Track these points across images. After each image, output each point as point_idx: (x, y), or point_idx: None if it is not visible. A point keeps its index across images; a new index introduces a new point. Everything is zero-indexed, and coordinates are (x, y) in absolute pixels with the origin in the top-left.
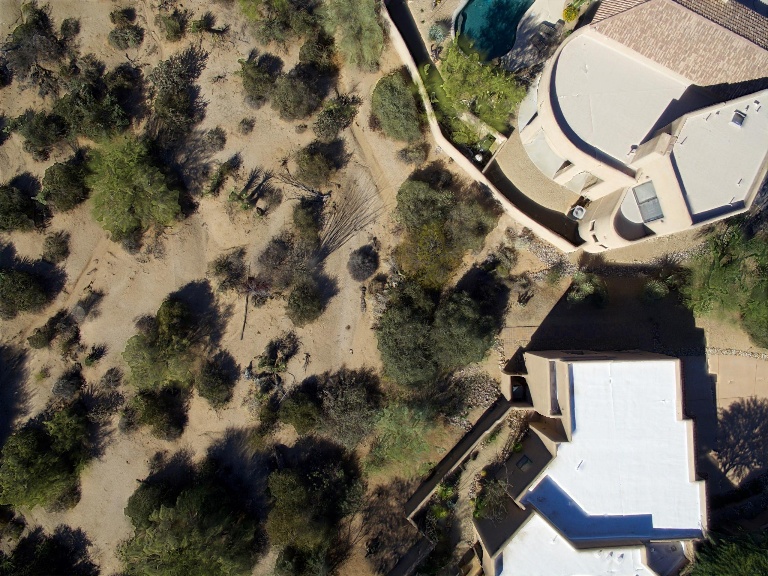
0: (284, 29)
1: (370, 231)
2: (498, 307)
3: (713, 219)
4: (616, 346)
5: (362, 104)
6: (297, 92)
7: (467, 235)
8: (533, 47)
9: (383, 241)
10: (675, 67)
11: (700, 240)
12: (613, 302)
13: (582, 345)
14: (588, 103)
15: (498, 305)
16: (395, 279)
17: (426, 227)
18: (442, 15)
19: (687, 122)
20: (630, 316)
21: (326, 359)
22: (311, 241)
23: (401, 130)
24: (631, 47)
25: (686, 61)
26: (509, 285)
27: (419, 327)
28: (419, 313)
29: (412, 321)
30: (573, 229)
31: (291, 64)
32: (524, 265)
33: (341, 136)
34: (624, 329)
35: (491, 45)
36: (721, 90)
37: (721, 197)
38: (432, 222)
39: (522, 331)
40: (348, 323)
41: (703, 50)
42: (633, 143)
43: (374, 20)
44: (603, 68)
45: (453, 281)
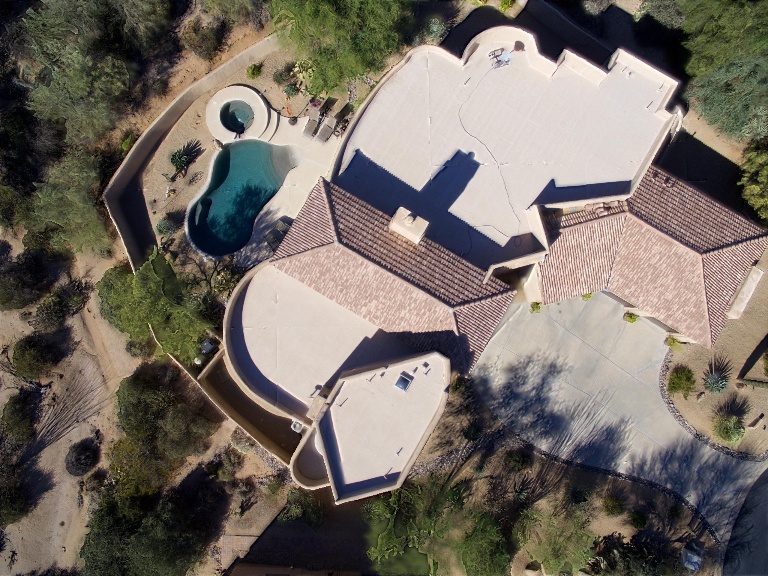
0: (13, 212)
1: (93, 423)
2: (219, 512)
3: (359, 496)
4: (336, 565)
5: (94, 290)
6: (6, 288)
7: (170, 449)
8: (268, 244)
9: (107, 434)
10: (357, 311)
11: (437, 454)
12: (335, 518)
13: (301, 561)
14: (275, 336)
15: (219, 510)
16: (114, 476)
17: (136, 432)
18: (176, 205)
19: (348, 382)
20: (353, 533)
21: (35, 557)
22: (23, 436)
23: (118, 328)
24: (312, 287)
25: (367, 306)
26: (229, 492)
27: (115, 541)
28: (122, 523)
29: (111, 533)
30: (301, 436)
31: (19, 248)
32: (250, 469)
33: (69, 323)
34: (346, 547)
35: (234, 233)
36: (406, 337)
37: (378, 467)
38: (147, 425)
39: (241, 540)
40: (62, 519)
41: (383, 298)
42: (318, 383)
43: (95, 214)
44: (294, 299)
45: (176, 480)
